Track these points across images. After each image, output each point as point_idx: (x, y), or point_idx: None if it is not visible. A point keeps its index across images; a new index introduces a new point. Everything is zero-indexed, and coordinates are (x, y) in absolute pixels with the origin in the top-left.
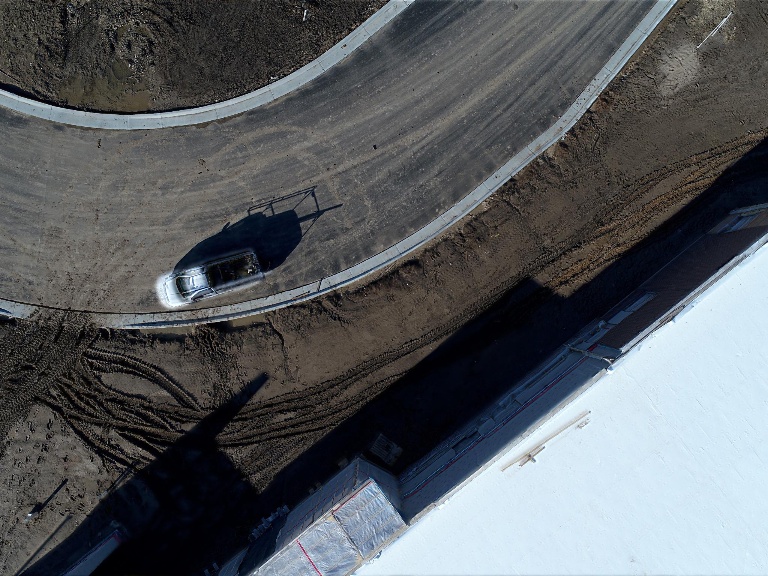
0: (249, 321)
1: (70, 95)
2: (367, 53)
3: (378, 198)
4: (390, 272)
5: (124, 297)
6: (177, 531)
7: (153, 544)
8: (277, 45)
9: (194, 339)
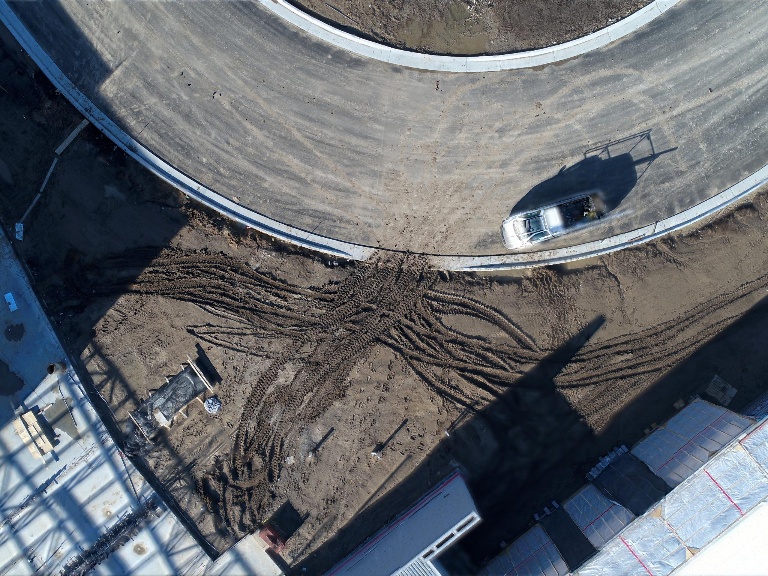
0: (583, 264)
1: (408, 37)
2: None
3: (713, 141)
4: (724, 215)
5: (461, 240)
6: (514, 470)
7: (491, 483)
8: None
9: (532, 281)
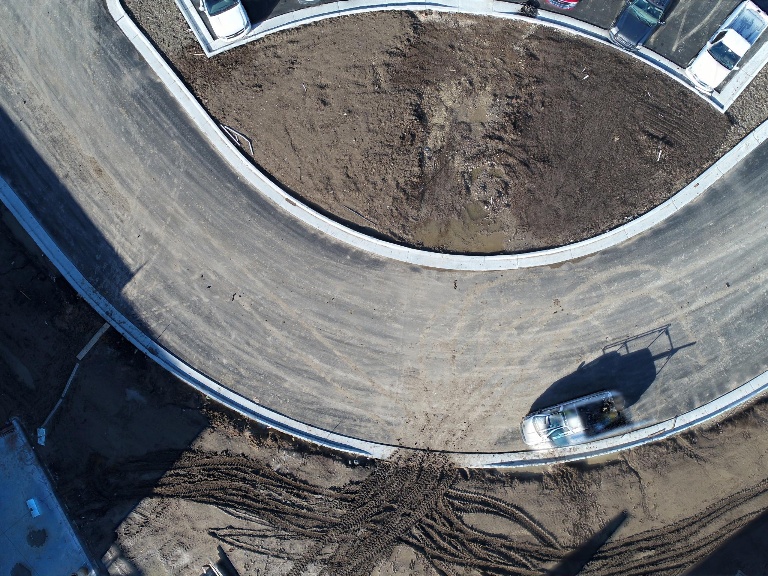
0: (604, 458)
1: (425, 237)
2: (719, 191)
3: (731, 335)
4: (743, 409)
5: (481, 437)
6: None
7: None
8: (632, 185)
9: (552, 478)
